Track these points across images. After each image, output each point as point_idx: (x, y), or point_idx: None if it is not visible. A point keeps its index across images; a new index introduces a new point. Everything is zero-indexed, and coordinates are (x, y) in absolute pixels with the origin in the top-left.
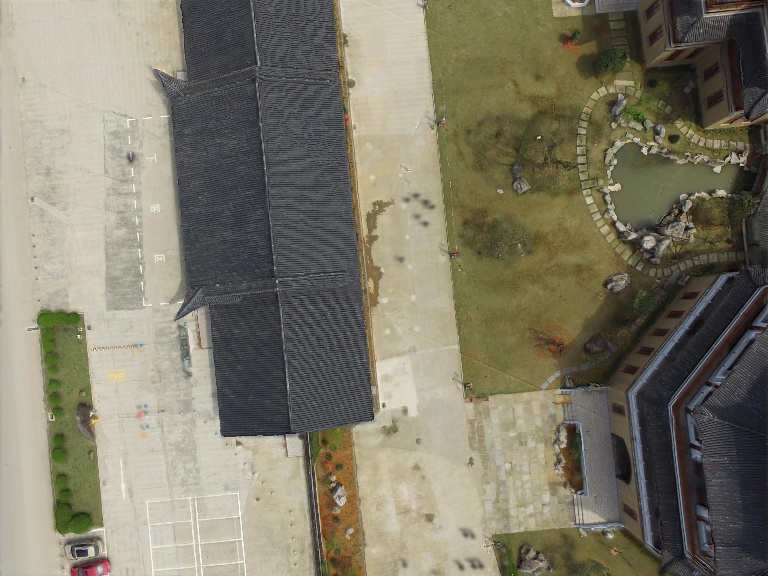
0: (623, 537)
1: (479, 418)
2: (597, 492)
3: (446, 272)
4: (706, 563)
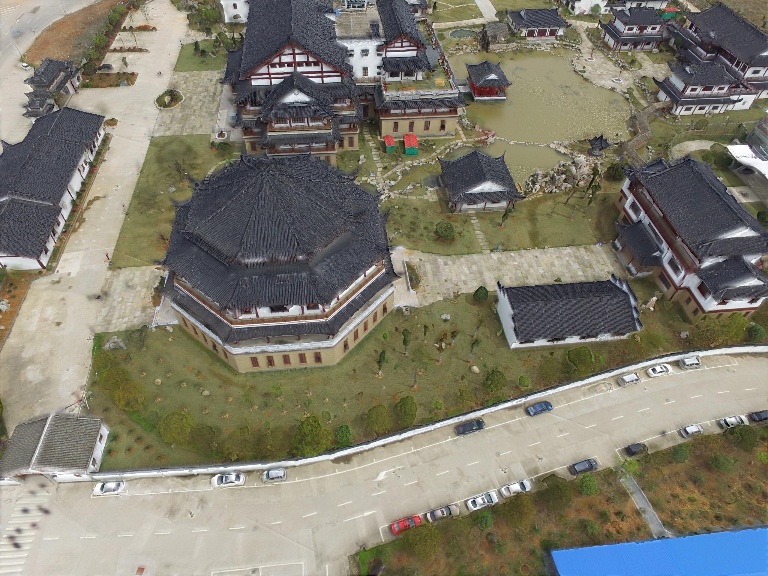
0: (179, 331)
1: (112, 278)
2: (169, 308)
3: (121, 221)
4: (180, 286)
